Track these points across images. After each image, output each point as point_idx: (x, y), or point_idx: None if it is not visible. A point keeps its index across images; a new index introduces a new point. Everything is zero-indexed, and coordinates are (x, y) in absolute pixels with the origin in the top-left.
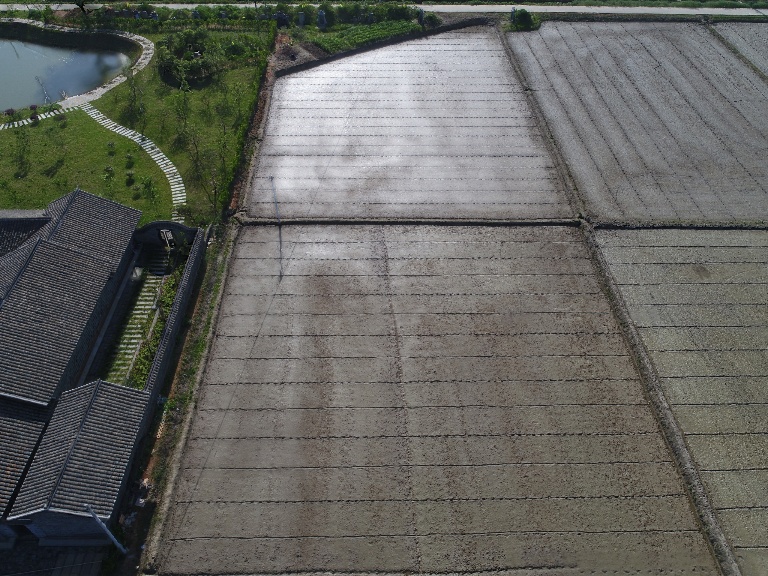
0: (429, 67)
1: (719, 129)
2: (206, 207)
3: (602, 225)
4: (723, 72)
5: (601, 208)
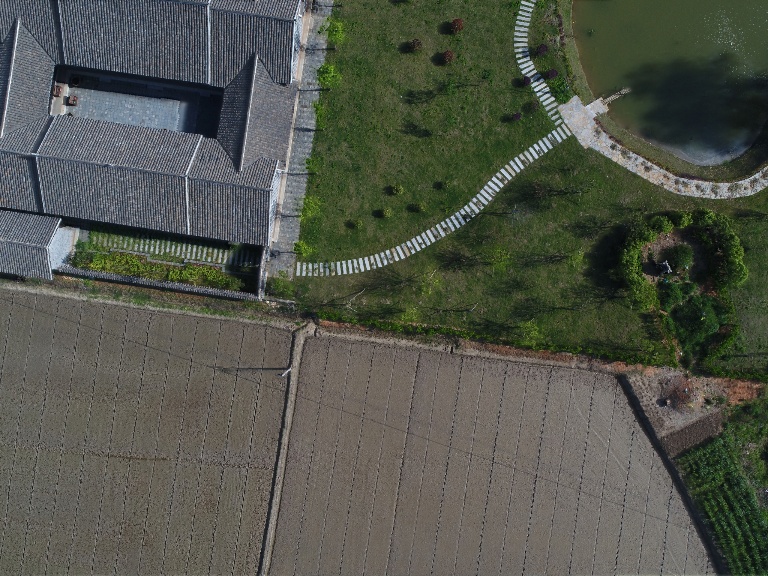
0: None
1: None
2: (322, 296)
3: None
4: None
5: None
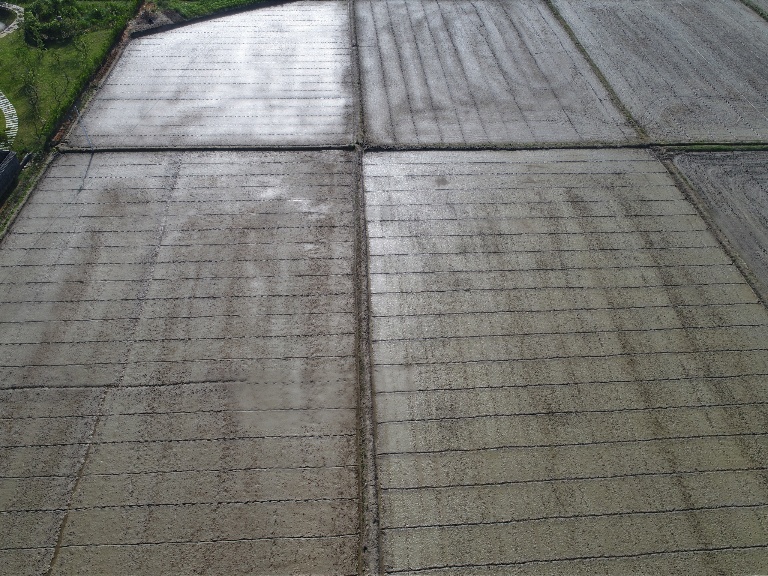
0: (274, 29)
1: (511, 75)
2: (31, 139)
3: (371, 148)
4: (537, 30)
5: (378, 136)
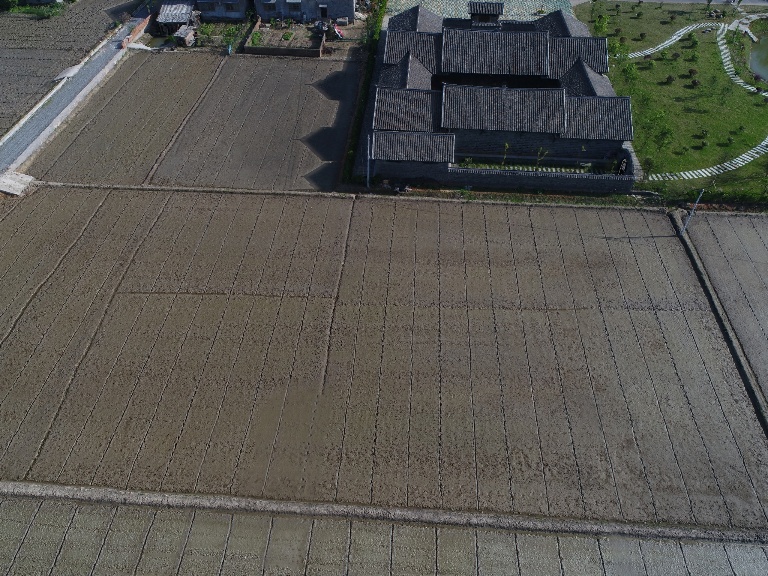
0: None
1: None
2: (681, 189)
3: None
4: None
5: None
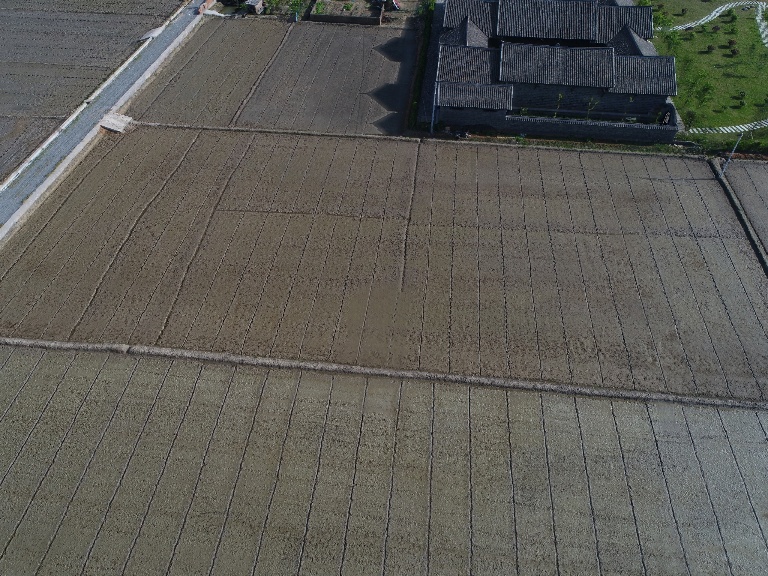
0: None
1: None
2: (720, 141)
3: None
4: None
5: None
